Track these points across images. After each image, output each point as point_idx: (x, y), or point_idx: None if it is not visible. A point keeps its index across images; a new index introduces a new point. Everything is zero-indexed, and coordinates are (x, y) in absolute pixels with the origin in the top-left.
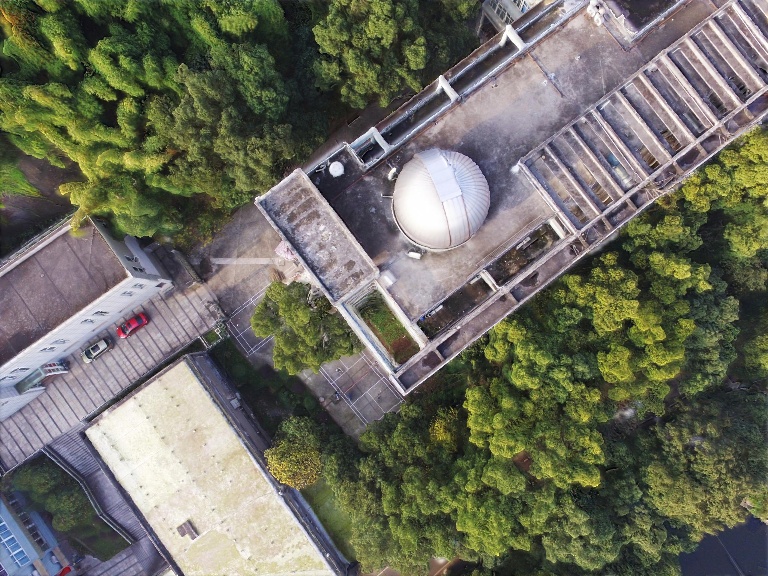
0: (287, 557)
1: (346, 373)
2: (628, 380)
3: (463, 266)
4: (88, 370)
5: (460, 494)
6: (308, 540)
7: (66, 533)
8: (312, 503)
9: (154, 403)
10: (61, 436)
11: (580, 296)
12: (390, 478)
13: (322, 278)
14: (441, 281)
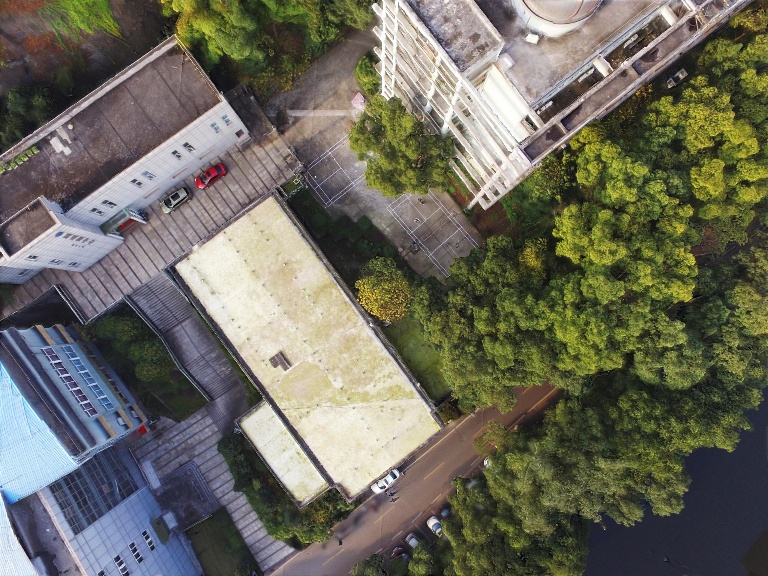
0: (379, 387)
1: (424, 223)
2: (719, 198)
3: (579, 51)
4: (166, 221)
5: (558, 306)
6: (399, 370)
7: (145, 388)
8: (396, 344)
9: (244, 237)
10: (141, 287)
11: (673, 115)
12: (481, 306)
13: (448, 50)
14: (558, 66)
